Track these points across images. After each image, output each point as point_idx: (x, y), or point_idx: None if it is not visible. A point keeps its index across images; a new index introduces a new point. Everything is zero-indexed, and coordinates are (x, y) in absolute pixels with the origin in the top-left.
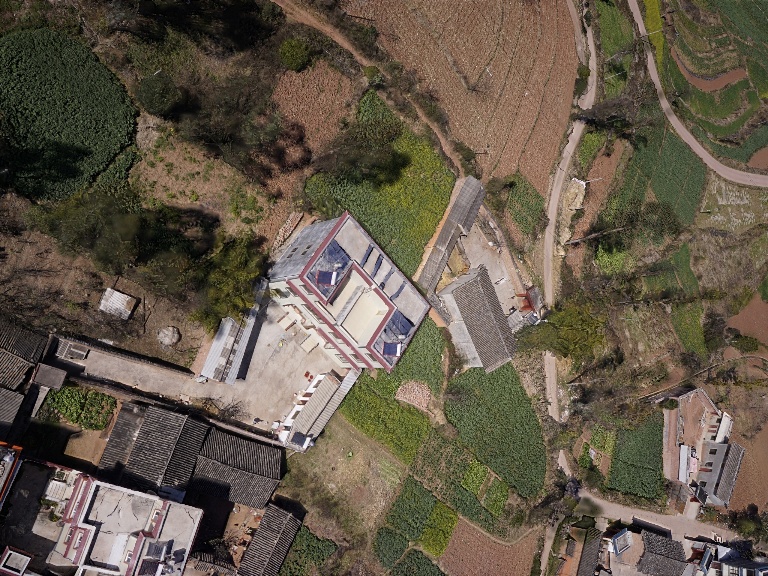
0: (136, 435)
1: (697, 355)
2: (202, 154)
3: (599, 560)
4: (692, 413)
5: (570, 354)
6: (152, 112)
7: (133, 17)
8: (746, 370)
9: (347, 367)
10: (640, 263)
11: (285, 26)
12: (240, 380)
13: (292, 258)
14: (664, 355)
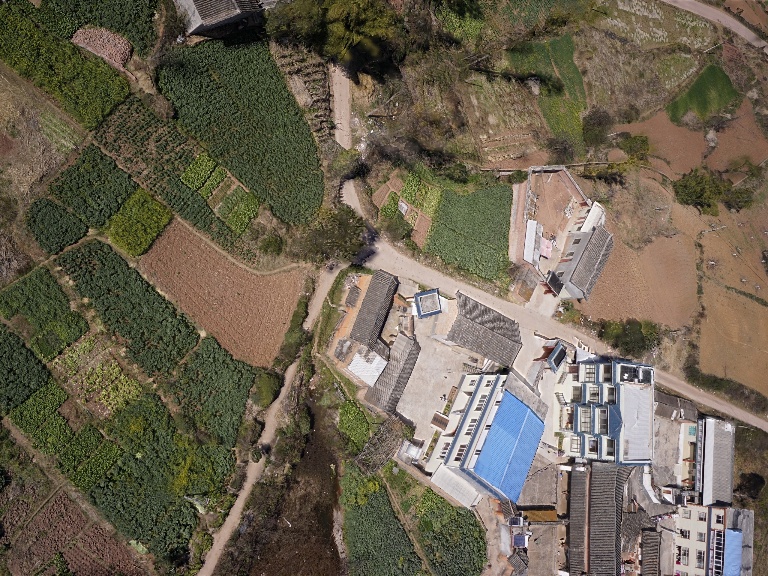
0: None
1: (570, 145)
2: None
3: (400, 326)
4: (553, 198)
5: (371, 79)
6: None
7: None
8: (638, 179)
9: None
10: (503, 38)
11: None
12: None
13: None
14: (524, 134)
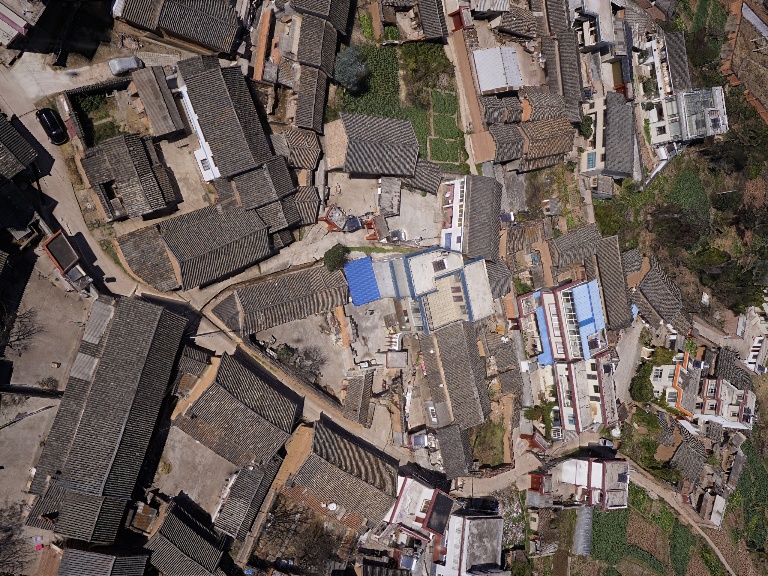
0: (713, 362)
1: None
2: (726, 226)
3: None
4: None
5: None
6: None
7: None
8: None
9: None
10: None
11: None
12: None
13: (761, 278)
14: None
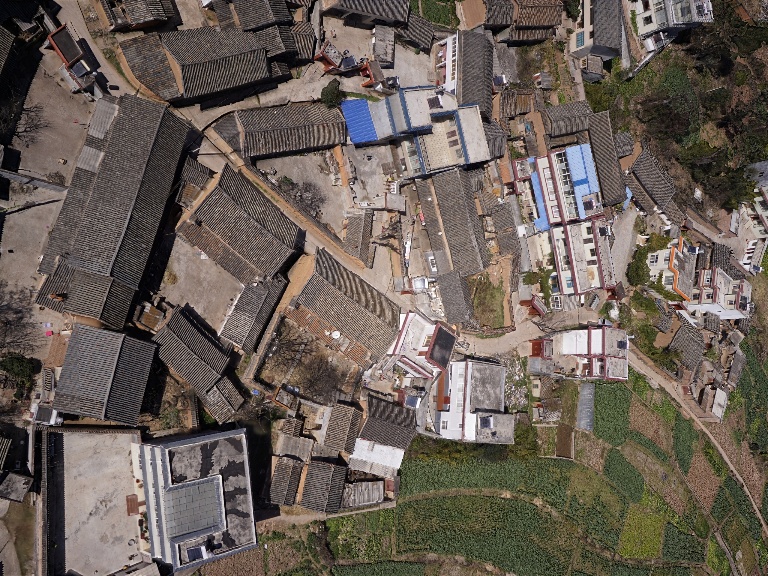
0: (708, 256)
1: None
2: (715, 127)
3: None
4: None
5: None
6: (713, 106)
7: (715, 62)
8: None
9: (762, 238)
10: None
11: (736, 64)
12: (729, 238)
13: (752, 179)
14: None
